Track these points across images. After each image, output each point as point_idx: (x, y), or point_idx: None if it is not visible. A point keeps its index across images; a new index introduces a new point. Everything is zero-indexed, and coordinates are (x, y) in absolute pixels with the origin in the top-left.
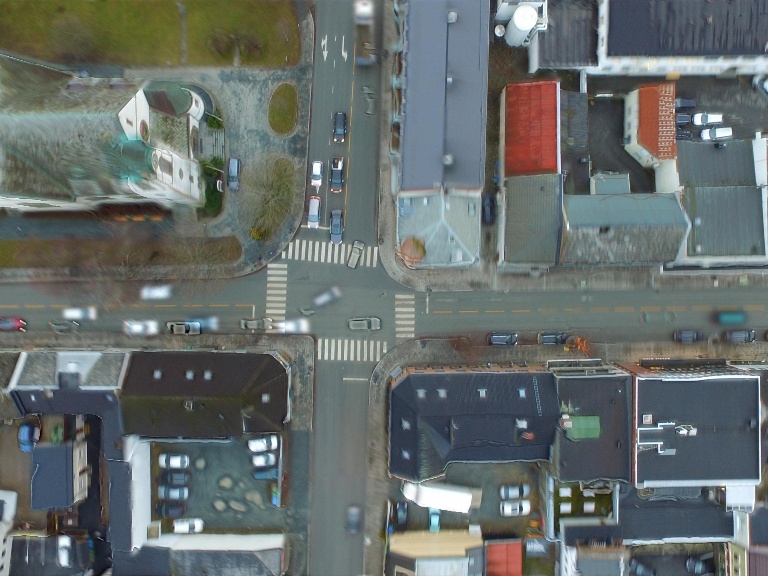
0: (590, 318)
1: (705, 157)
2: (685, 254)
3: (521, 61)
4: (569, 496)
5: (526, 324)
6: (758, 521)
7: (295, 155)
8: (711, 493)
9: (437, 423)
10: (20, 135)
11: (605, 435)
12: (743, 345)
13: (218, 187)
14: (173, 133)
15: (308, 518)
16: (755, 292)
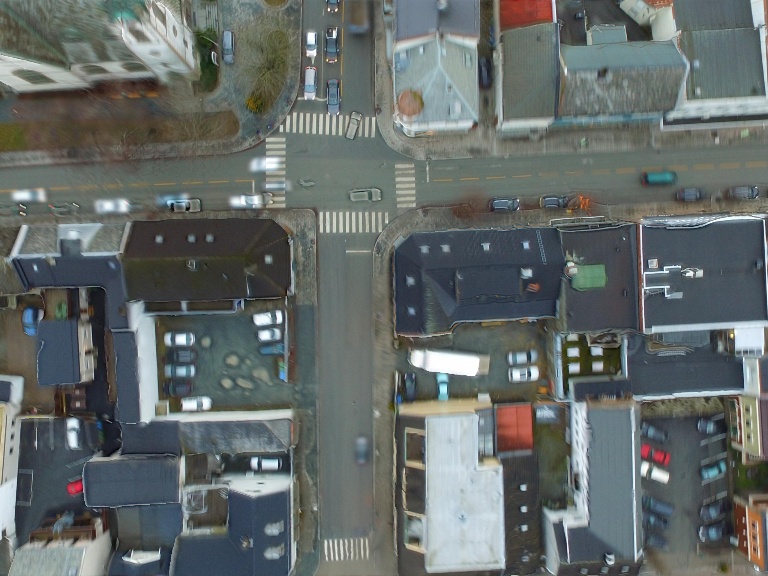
0: (592, 180)
1: (701, 3)
2: (685, 98)
3: None
4: (577, 356)
5: (527, 189)
6: None
7: (289, 27)
8: (720, 345)
9: (442, 276)
10: None
11: (611, 283)
12: (746, 200)
13: (213, 58)
14: None
15: (316, 393)
16: (757, 148)
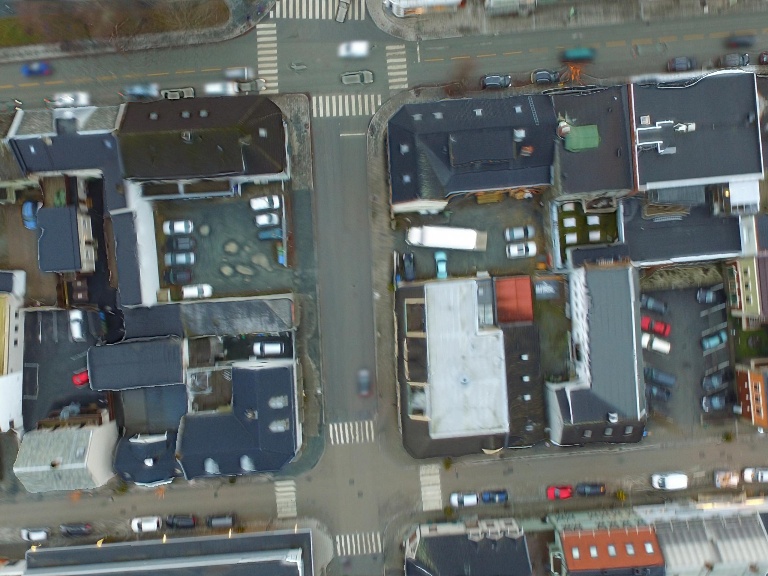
0: (582, 54)
1: None
2: None
3: None
4: (574, 226)
5: (518, 65)
6: (765, 226)
7: None
8: (716, 208)
9: (435, 142)
10: None
11: (604, 143)
12: None
13: None
14: None
15: (316, 278)
16: (746, 16)
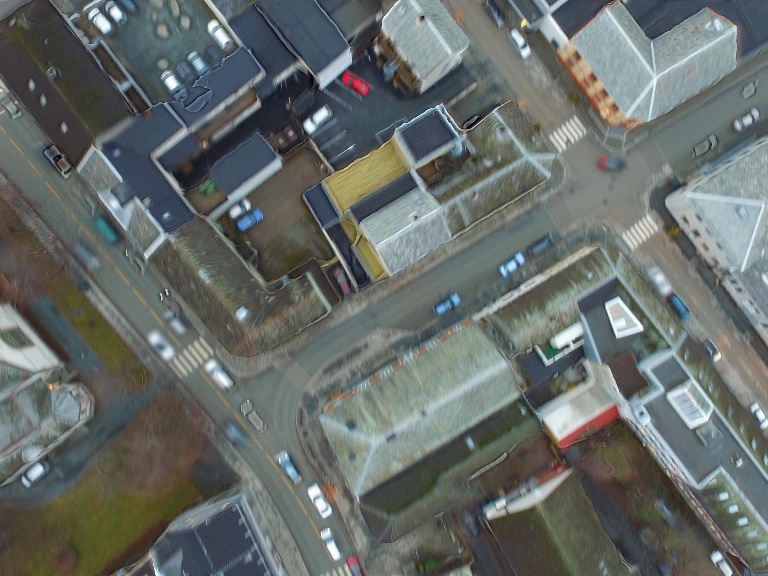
0: None
1: None
2: None
3: None
4: None
5: None
6: None
7: None
8: None
9: None
10: None
11: None
12: None
13: None
14: None
15: None
16: None
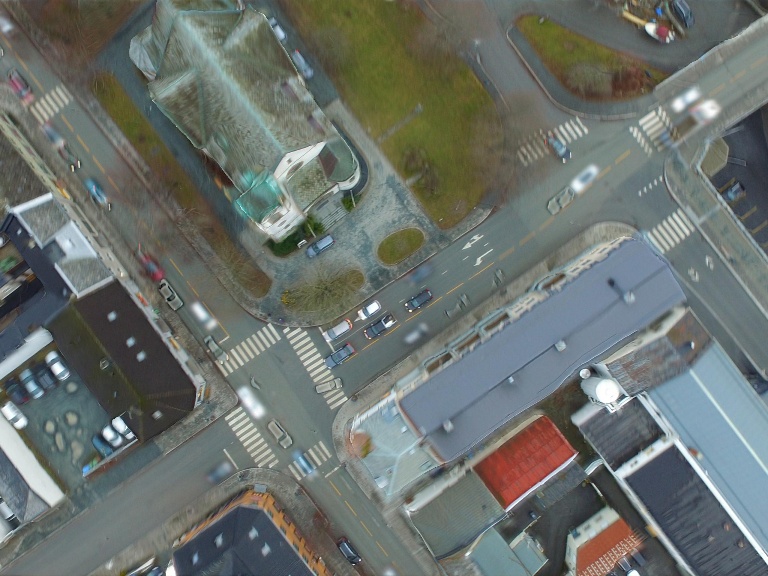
0: None
1: None
2: None
3: (576, 403)
4: None
5: (375, 560)
6: None
7: (371, 281)
8: None
9: (238, 565)
10: (215, 85)
11: None
12: None
13: (300, 243)
14: (313, 185)
15: (93, 503)
16: None
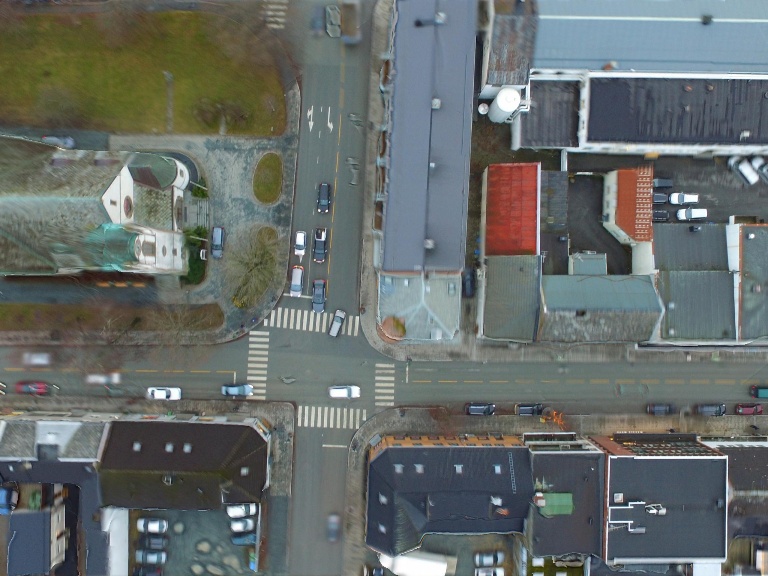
0: (566, 390)
1: (680, 240)
2: (659, 336)
3: (504, 137)
4: (542, 566)
5: (504, 395)
6: None
7: (279, 224)
8: (679, 566)
9: (413, 499)
10: (3, 214)
11: (577, 512)
12: (714, 419)
13: (201, 256)
14: (157, 206)
15: None
16: (726, 367)
